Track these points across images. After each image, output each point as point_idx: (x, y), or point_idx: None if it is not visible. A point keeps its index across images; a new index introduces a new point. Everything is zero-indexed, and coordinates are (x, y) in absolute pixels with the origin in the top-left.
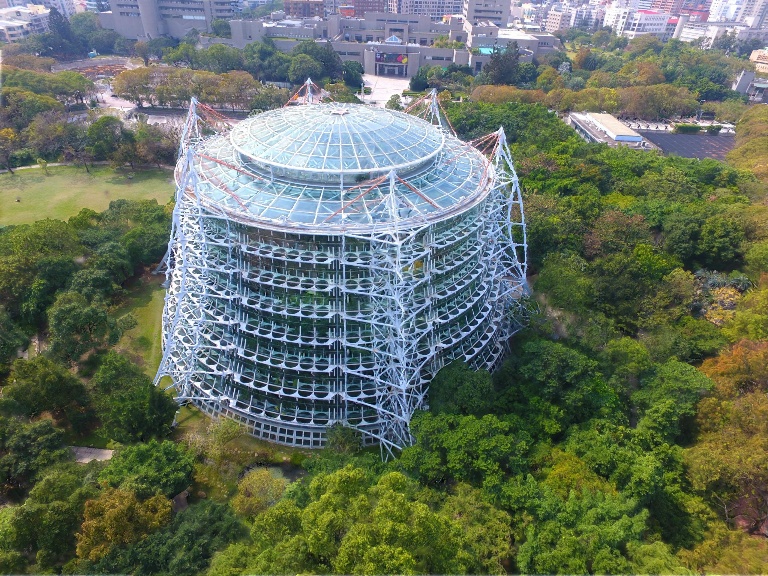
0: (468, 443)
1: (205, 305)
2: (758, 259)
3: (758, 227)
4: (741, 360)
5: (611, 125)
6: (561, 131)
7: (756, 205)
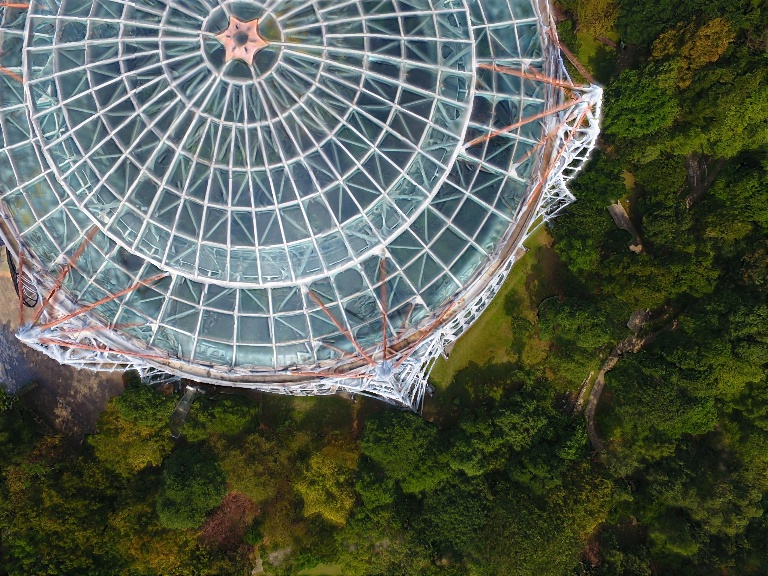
0: None
1: None
2: None
3: None
4: None
5: None
6: None
7: None
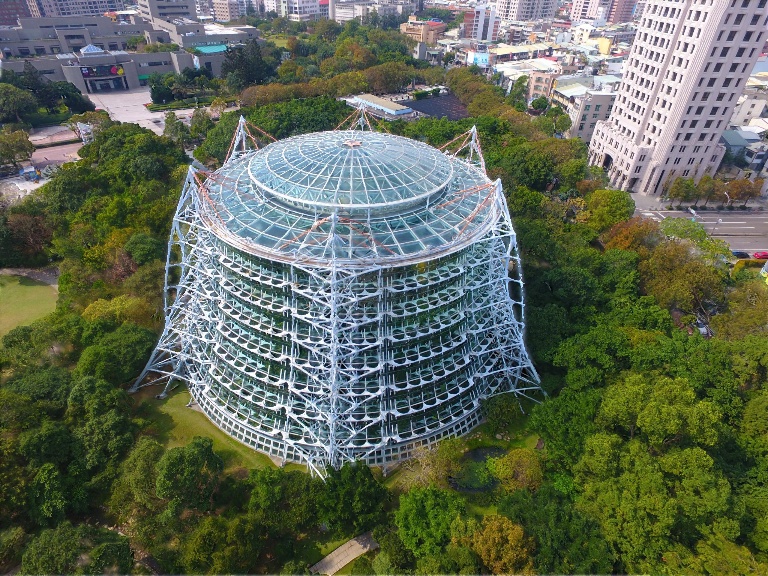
0: (608, 346)
1: (338, 366)
2: (571, 175)
3: (556, 155)
4: (632, 235)
5: (382, 103)
6: (368, 117)
7: (532, 141)
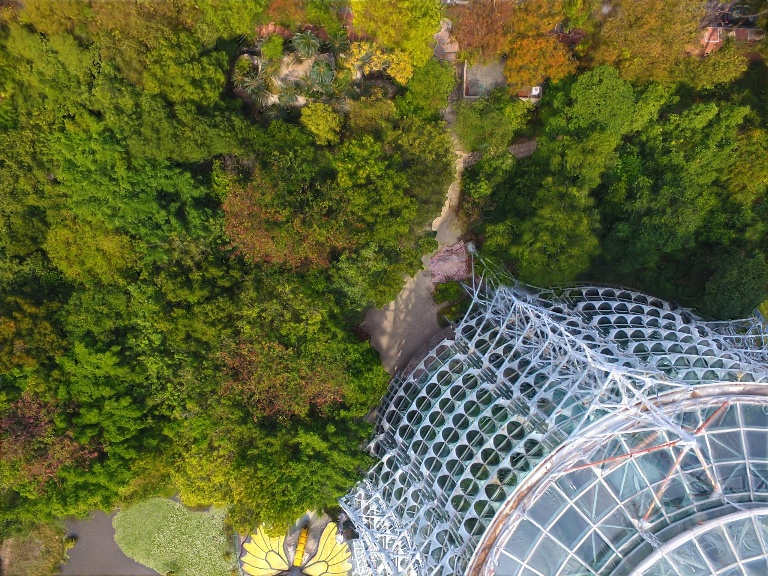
0: None
1: None
2: None
3: (156, 11)
4: None
5: None
6: None
7: None
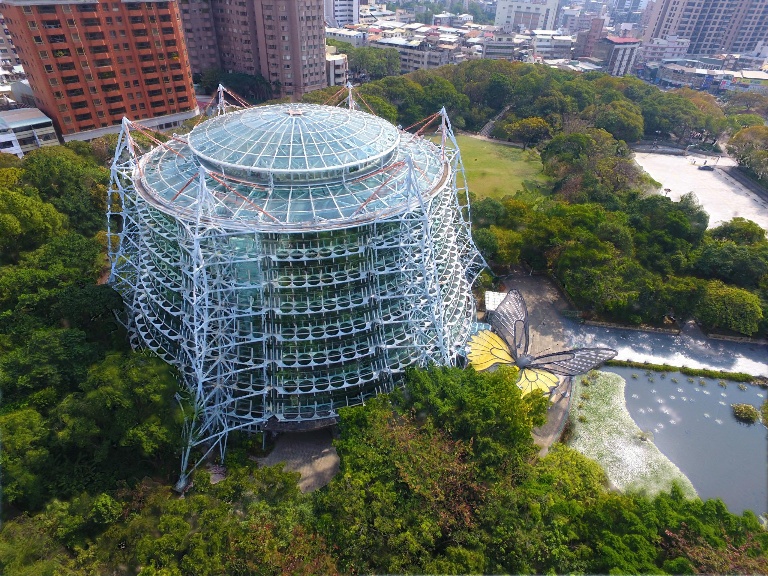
0: None
1: None
2: None
3: None
4: None
5: None
6: None
7: None
